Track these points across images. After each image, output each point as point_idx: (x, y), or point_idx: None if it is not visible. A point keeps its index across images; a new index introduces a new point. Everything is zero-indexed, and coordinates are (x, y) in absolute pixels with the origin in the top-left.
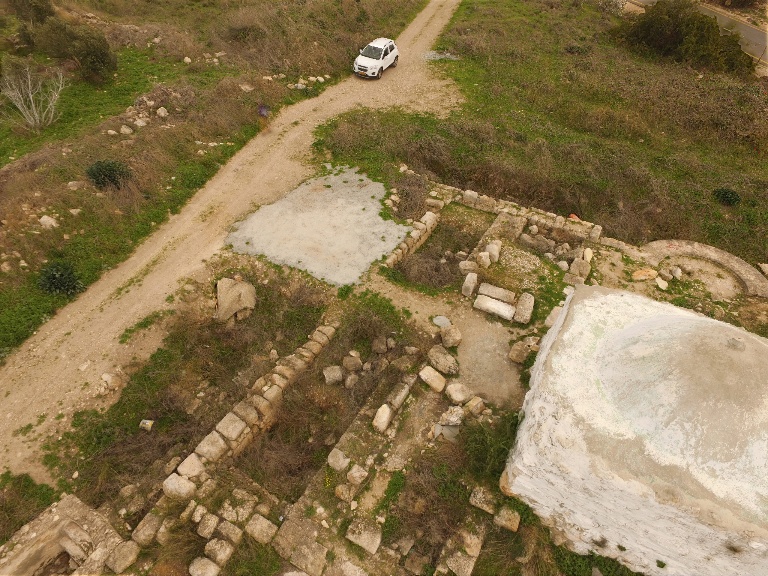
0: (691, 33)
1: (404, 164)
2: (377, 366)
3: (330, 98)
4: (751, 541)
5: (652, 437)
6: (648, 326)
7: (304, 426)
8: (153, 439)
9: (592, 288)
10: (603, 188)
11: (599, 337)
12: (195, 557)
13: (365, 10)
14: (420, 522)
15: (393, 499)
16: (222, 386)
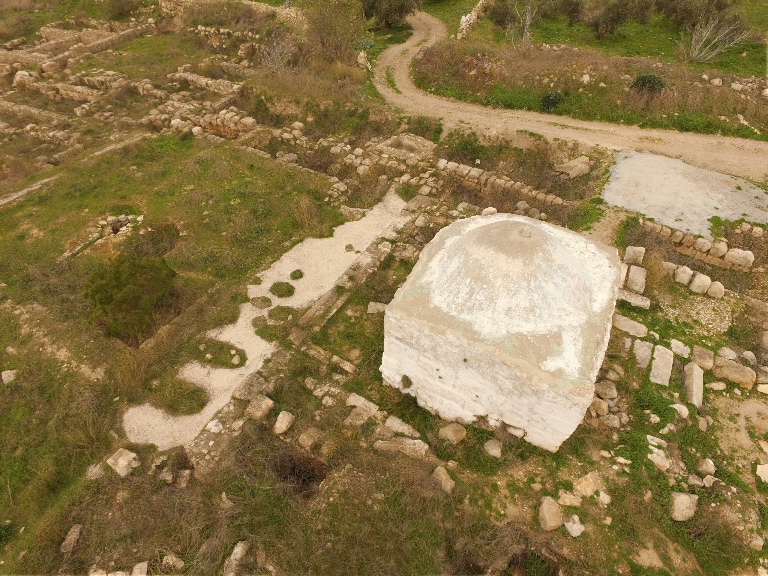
0: None
1: None
2: None
3: None
4: None
5: None
6: None
7: None
8: None
9: (614, 253)
10: None
11: None
12: None
13: None
14: None
15: None
16: None
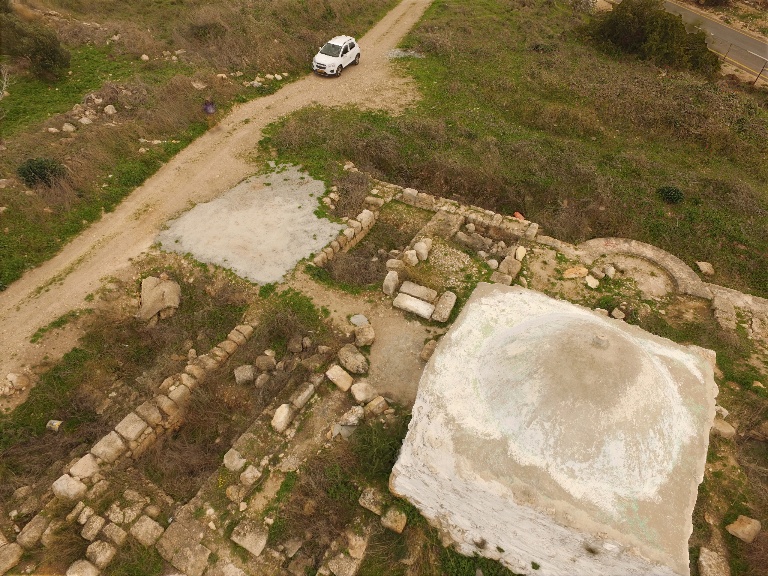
0: (655, 31)
1: (350, 162)
2: (289, 365)
3: (285, 96)
4: (605, 543)
5: (516, 437)
6: (530, 324)
7: (212, 426)
8: (58, 440)
9: (493, 286)
10: (548, 186)
11: (487, 335)
12: (76, 560)
13: (332, 8)
14: (308, 523)
15: (283, 500)
16: (135, 386)
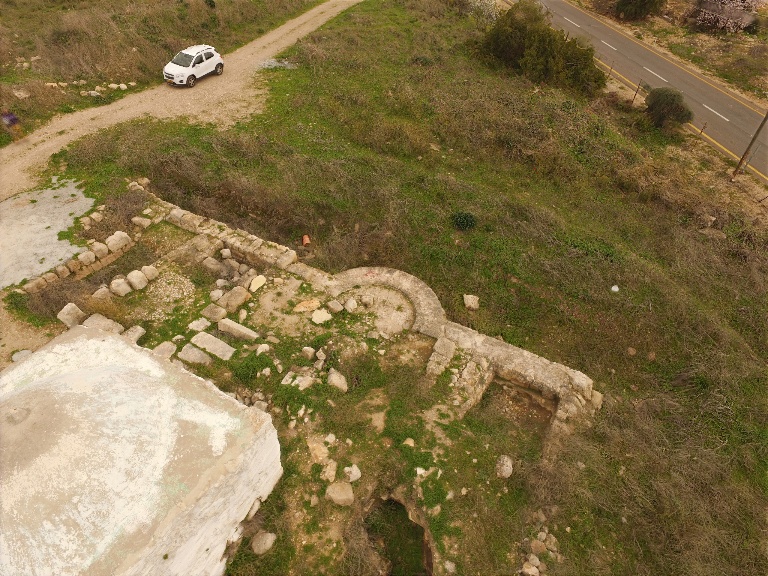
0: (532, 46)
1: (145, 178)
2: None
3: (121, 106)
4: None
5: None
6: None
7: None
8: None
9: (84, 330)
10: (340, 208)
11: None
12: None
13: (217, 16)
14: None
15: None
16: None
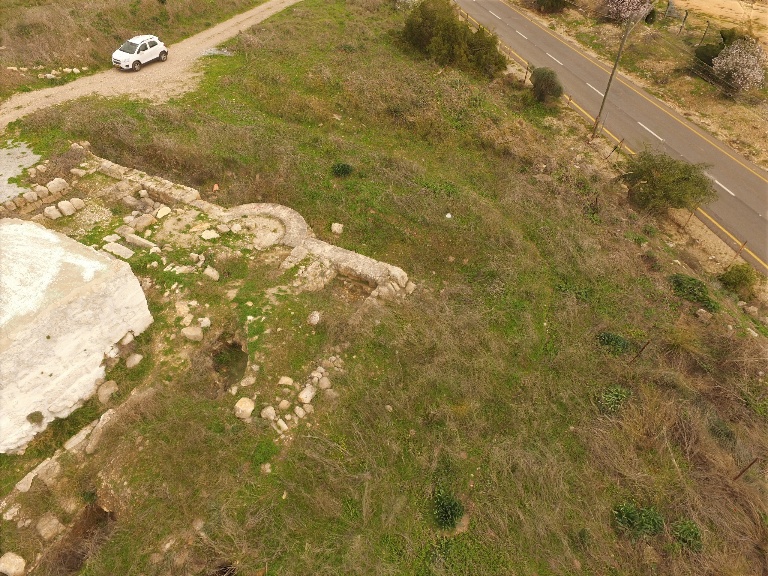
0: (438, 34)
1: (86, 141)
2: None
3: (73, 87)
4: None
5: None
6: None
7: None
8: None
9: (9, 220)
10: (244, 162)
11: None
12: None
13: (167, 11)
14: None
15: None
16: None
